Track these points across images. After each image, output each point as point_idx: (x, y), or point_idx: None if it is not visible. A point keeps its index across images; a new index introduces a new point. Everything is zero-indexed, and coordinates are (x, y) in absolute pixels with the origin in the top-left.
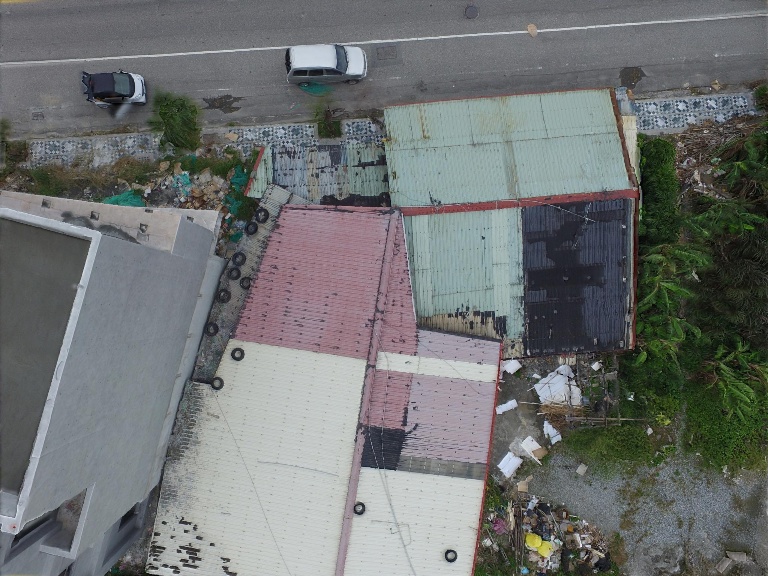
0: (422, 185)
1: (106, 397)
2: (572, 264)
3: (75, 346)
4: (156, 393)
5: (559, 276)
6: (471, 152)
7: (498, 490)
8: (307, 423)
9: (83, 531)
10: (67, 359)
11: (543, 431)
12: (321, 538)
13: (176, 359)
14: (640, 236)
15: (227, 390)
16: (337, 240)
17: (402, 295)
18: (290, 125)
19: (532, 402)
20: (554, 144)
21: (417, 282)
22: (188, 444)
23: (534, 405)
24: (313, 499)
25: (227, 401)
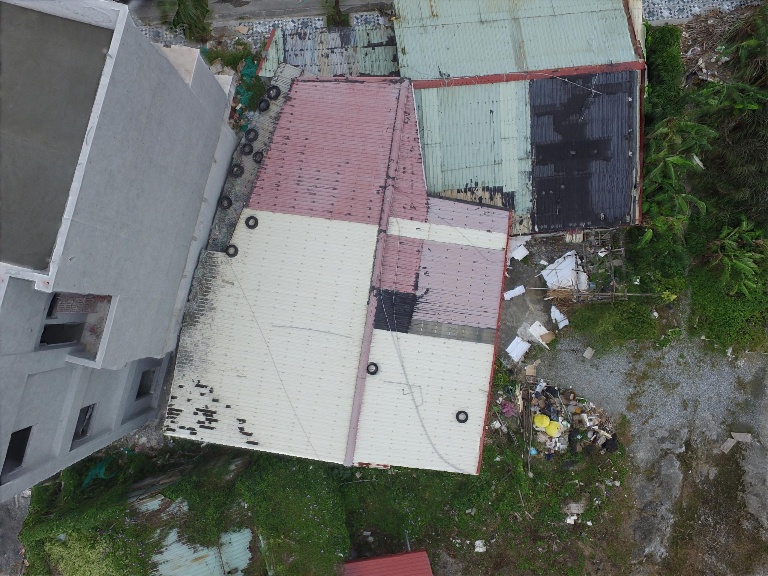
0: (431, 60)
1: (130, 204)
2: (579, 138)
3: (104, 119)
4: (174, 240)
5: (566, 150)
6: (479, 29)
7: (507, 372)
8: (320, 287)
9: (108, 343)
10: (96, 128)
11: (550, 316)
12: (335, 398)
13: (192, 217)
14: (645, 120)
15: (241, 257)
16: (348, 110)
17: (412, 163)
18: (299, 18)
19: (539, 287)
20: (561, 21)
21: (427, 157)
22: (203, 310)
23: (541, 291)
24: (327, 360)
25: (241, 268)
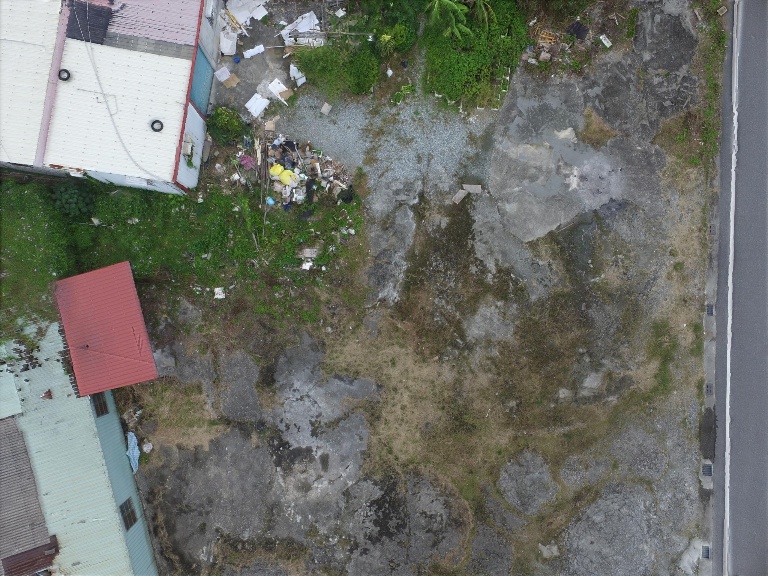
0: None
1: None
2: None
3: None
4: None
5: None
6: None
7: None
8: None
9: None
10: None
11: (289, 74)
12: (27, 102)
13: None
14: None
15: None
16: None
17: None
18: None
19: None
20: None
21: None
22: None
23: (281, 50)
24: (20, 68)
25: None
